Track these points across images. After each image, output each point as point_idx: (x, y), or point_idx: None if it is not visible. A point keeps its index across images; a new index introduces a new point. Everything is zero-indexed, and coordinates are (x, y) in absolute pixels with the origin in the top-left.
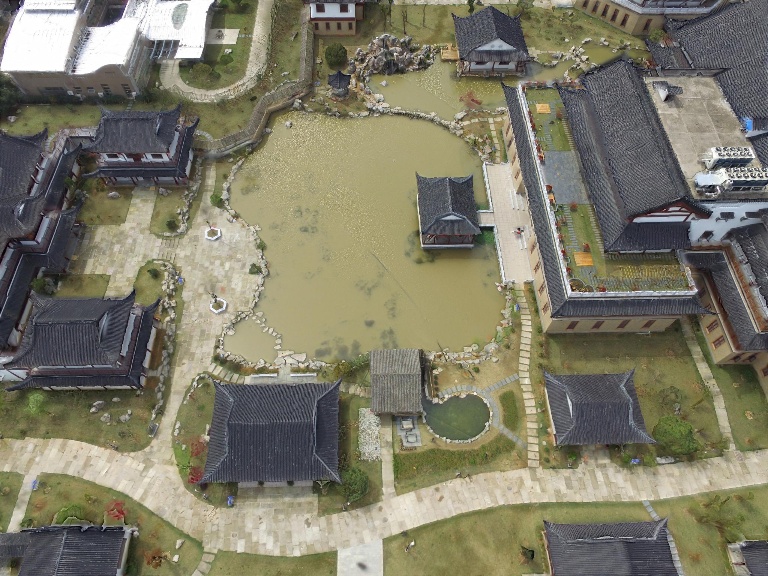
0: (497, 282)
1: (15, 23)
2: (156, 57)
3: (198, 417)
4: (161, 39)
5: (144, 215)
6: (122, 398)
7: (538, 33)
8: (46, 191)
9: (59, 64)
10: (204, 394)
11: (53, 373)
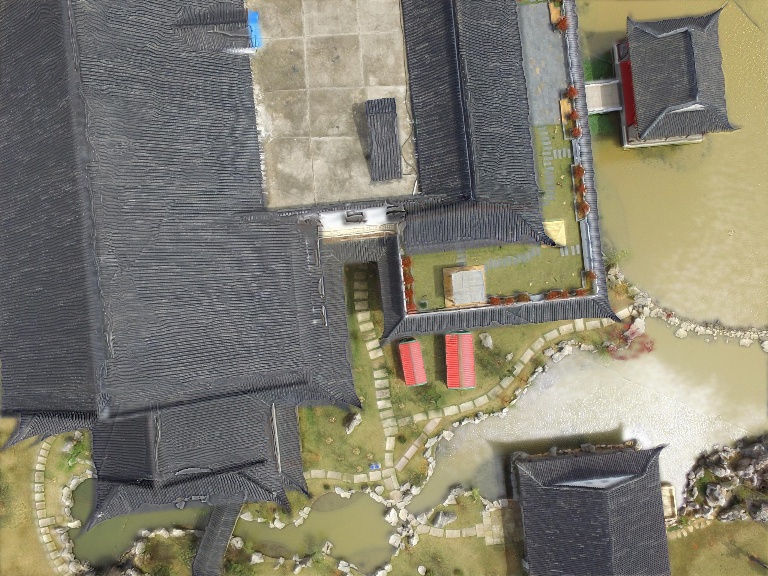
0: None
1: None
2: None
3: None
4: None
5: None
6: None
7: None
8: None
9: None
10: None
11: None
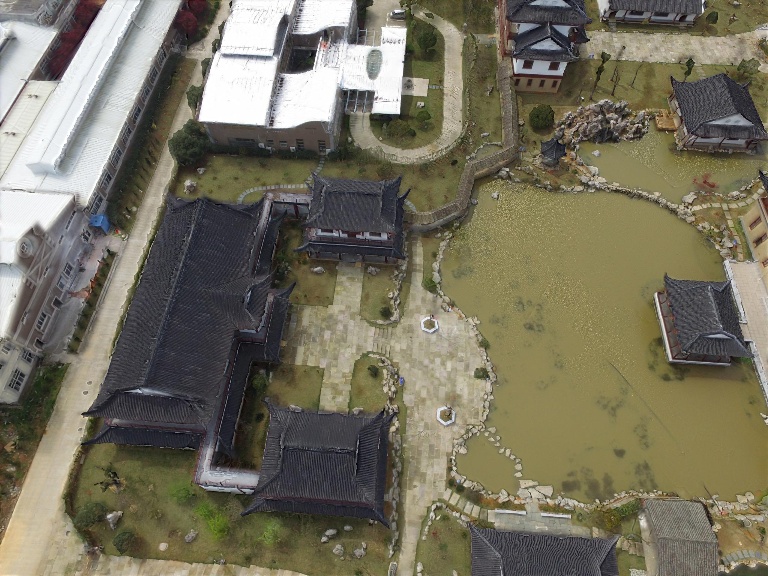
0: (763, 413)
1: (213, 69)
2: (351, 110)
3: (442, 559)
4: (355, 89)
5: (352, 296)
6: (354, 526)
7: (762, 102)
8: (256, 266)
9: (260, 117)
10: (445, 530)
11: (292, 499)
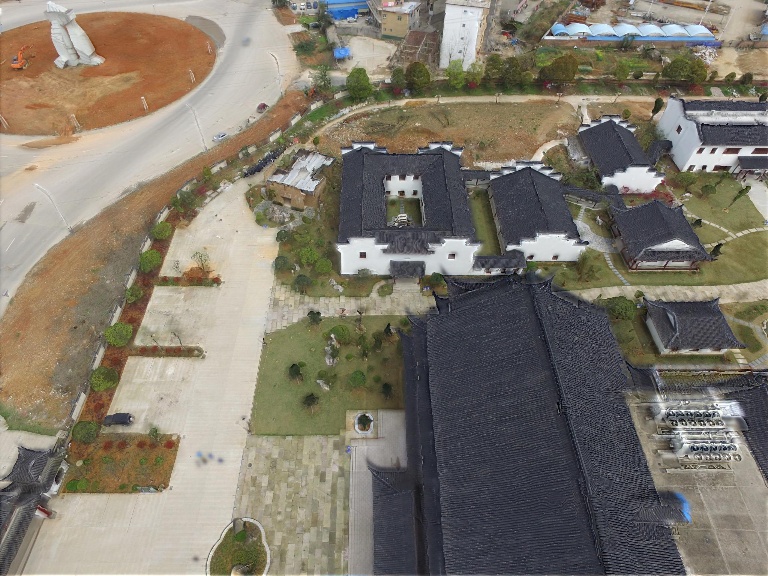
0: None
1: None
2: None
3: None
4: None
5: None
6: None
7: None
8: None
9: None
10: None
11: None
